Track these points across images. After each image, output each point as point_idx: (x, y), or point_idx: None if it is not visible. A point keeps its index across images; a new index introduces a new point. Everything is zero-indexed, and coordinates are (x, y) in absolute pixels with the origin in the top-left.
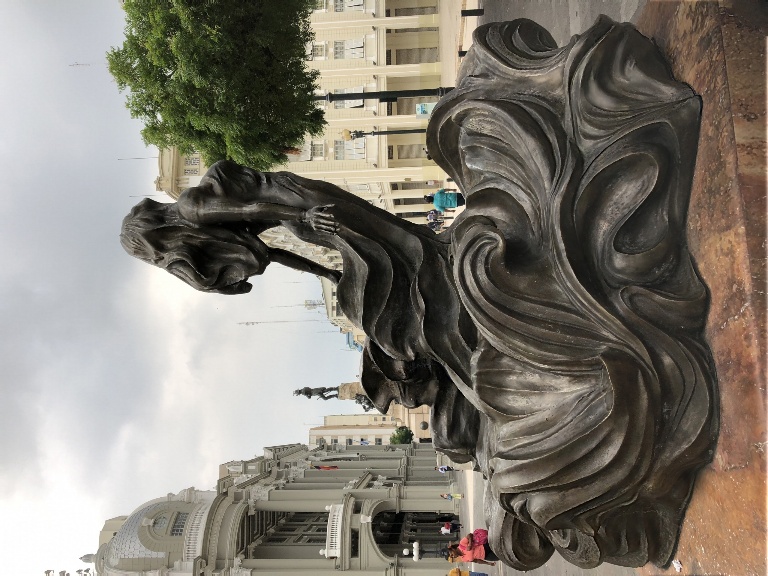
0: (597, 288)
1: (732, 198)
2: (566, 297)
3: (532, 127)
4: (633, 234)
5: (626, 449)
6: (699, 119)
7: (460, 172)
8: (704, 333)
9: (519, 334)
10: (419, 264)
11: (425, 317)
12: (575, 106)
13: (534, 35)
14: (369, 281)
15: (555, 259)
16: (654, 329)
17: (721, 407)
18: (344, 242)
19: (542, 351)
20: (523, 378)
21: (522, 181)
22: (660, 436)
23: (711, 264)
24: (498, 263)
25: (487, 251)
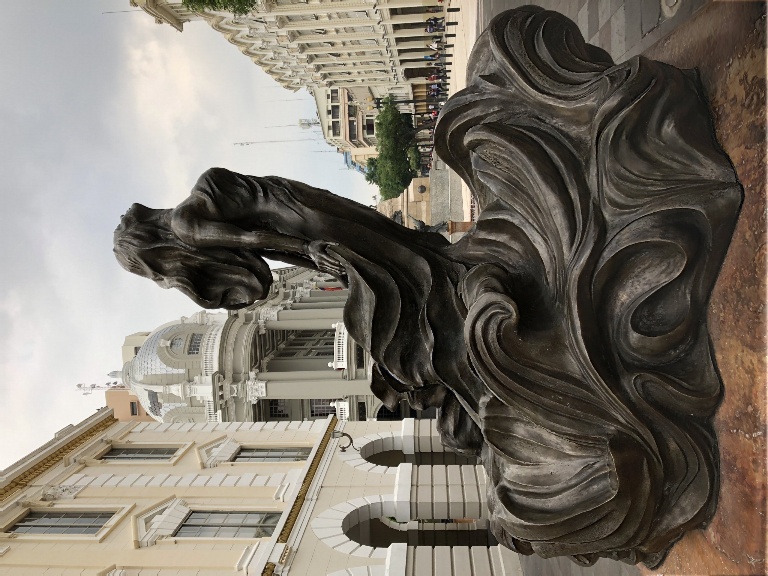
0: (610, 365)
1: (761, 323)
2: (578, 369)
3: (553, 179)
4: (652, 305)
5: (625, 525)
6: (738, 212)
7: (471, 173)
8: (713, 419)
9: (529, 402)
10: (427, 290)
11: (434, 349)
12: (602, 162)
13: (560, 35)
14: (377, 310)
15: (569, 330)
16: (664, 418)
17: (720, 496)
18: (349, 264)
19: (551, 422)
20: (530, 427)
21: (538, 225)
22: (659, 511)
23: (729, 365)
24: (510, 331)
25: (500, 319)
